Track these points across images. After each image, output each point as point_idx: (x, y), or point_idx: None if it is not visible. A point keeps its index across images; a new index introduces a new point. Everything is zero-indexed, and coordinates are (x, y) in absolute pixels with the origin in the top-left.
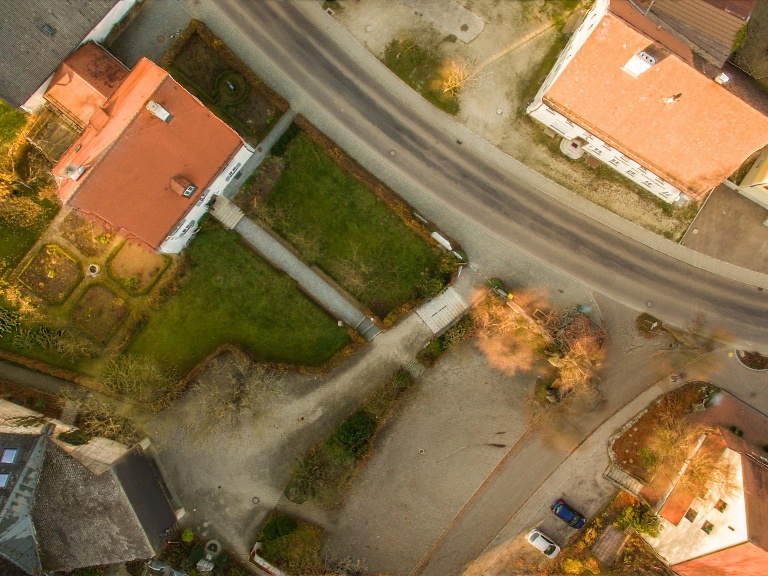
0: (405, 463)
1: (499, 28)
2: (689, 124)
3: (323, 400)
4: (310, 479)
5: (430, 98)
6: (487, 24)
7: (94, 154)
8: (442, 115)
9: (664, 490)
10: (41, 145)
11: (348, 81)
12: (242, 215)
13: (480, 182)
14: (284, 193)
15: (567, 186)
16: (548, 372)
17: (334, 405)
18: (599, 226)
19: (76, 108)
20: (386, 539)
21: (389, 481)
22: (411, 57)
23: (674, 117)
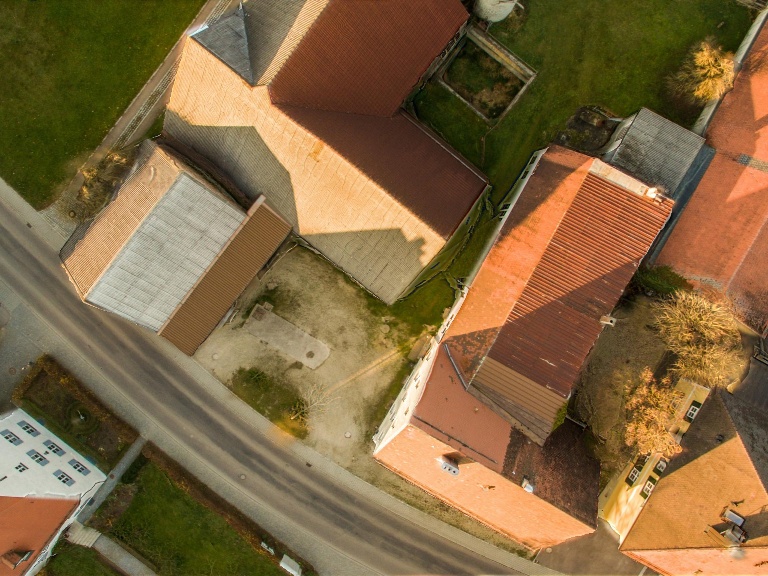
0: None
1: (345, 355)
2: (509, 506)
3: None
4: None
5: (278, 423)
6: (333, 351)
7: None
8: (291, 439)
9: None
10: None
11: (197, 408)
12: (99, 534)
13: (331, 504)
14: (139, 513)
15: (418, 507)
16: None
17: None
18: (452, 545)
19: None
20: None
21: None
22: (258, 384)
23: (494, 498)
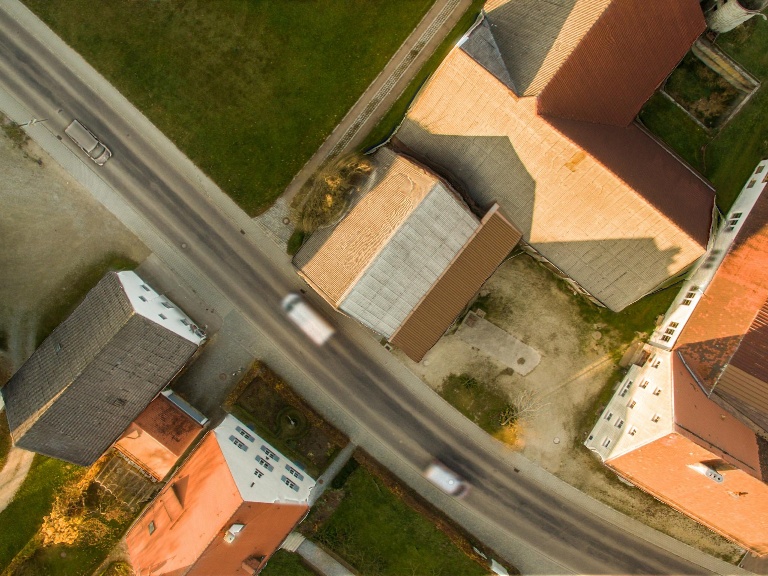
0: None
1: (556, 361)
2: (754, 512)
3: None
4: None
5: (488, 429)
6: (544, 357)
7: (171, 564)
8: (499, 445)
9: None
10: (111, 488)
11: (406, 413)
12: (303, 539)
13: (538, 509)
14: (344, 517)
15: (625, 512)
16: None
17: None
18: (657, 549)
19: (144, 457)
20: None
21: None
22: (468, 390)
23: (739, 504)
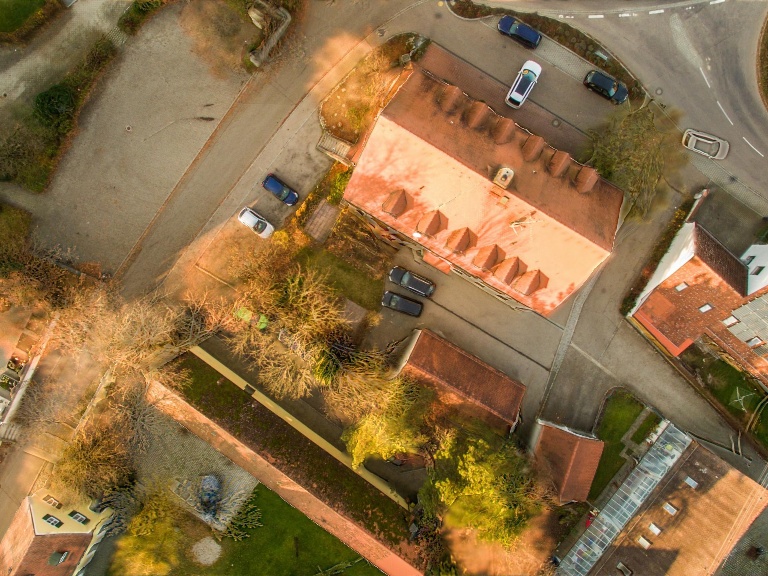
0: (112, 142)
1: None
2: None
3: (25, 74)
4: (12, 157)
5: None
6: None
7: None
8: None
9: (362, 141)
10: None
11: None
12: None
13: None
14: None
15: None
16: (254, 36)
17: (36, 80)
18: None
19: None
20: (96, 225)
21: (96, 161)
22: None
23: None
